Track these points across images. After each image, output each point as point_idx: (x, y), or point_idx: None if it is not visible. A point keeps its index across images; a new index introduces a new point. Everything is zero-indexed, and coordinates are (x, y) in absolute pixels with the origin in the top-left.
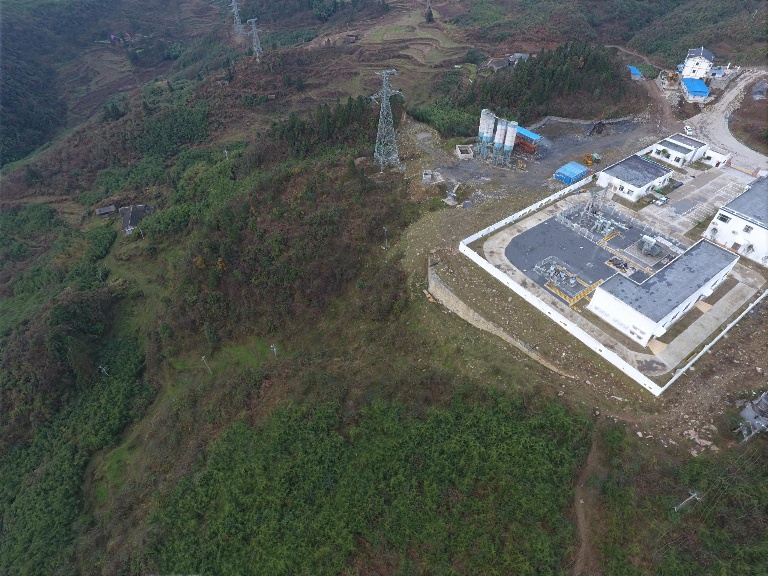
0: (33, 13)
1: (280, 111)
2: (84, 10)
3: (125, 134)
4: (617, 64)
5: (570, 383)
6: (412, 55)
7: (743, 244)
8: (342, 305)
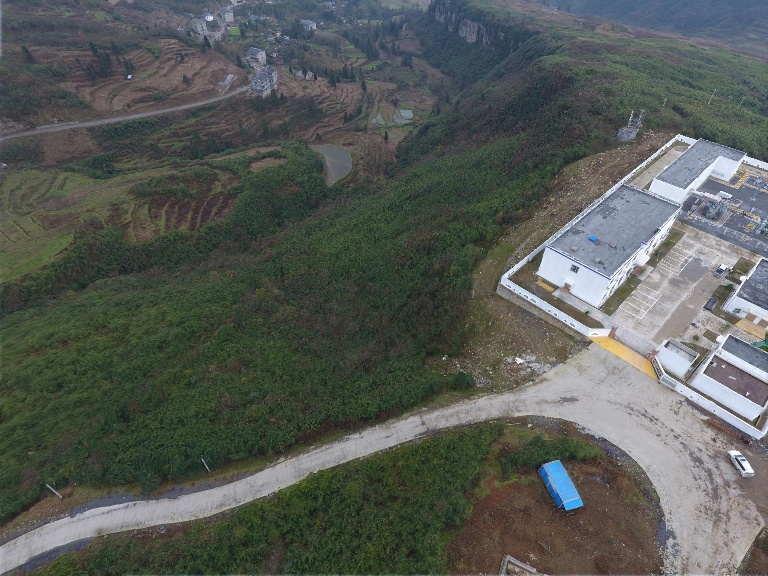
0: None
1: None
2: None
3: None
4: None
5: None
6: None
7: None
8: None
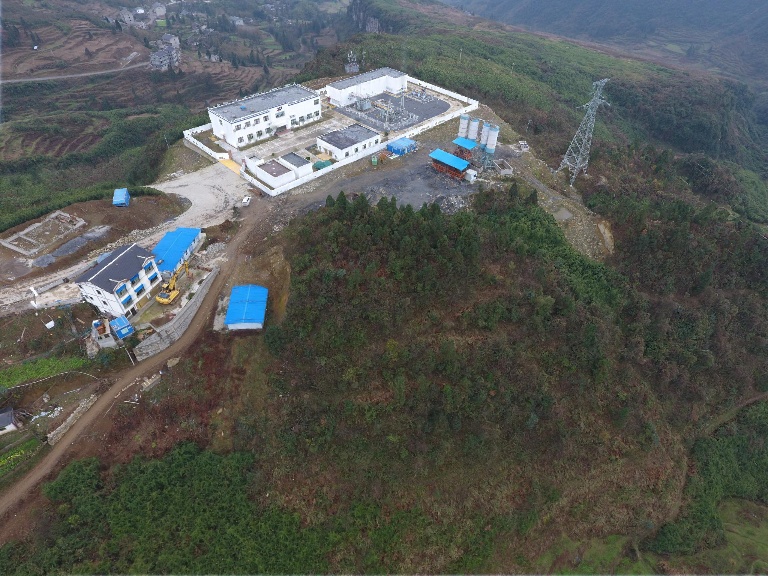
0: None
1: None
2: None
3: None
4: None
5: None
6: None
7: None
8: None
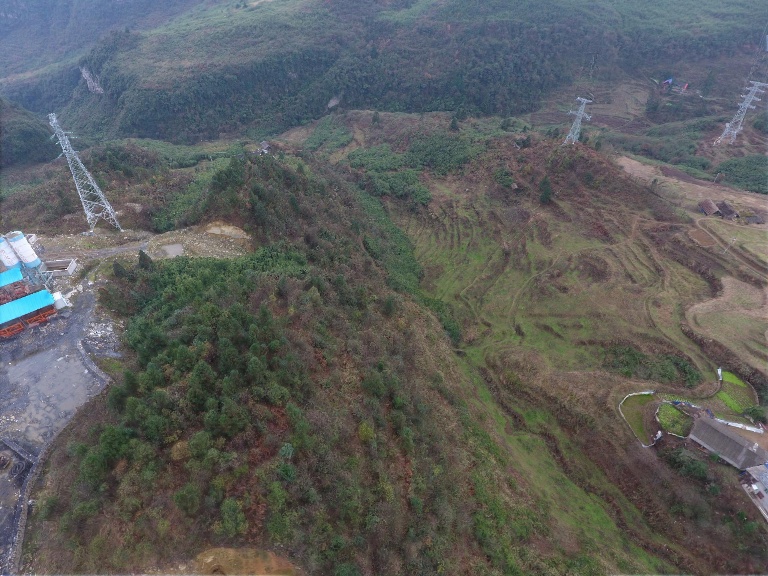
0: (633, 32)
1: (492, 202)
2: (678, 47)
3: (420, 131)
4: (122, 496)
5: None
6: (724, 295)
7: None
8: None
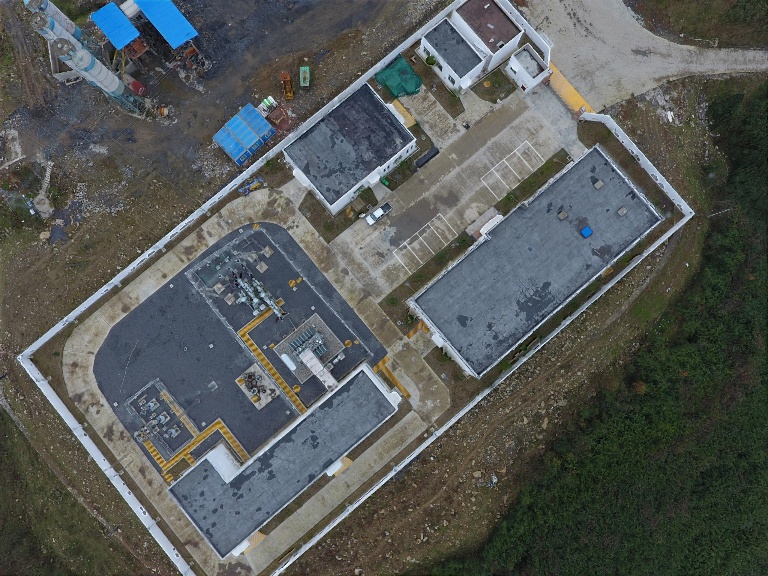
0: None
1: None
2: None
3: None
4: None
5: (152, 575)
6: None
7: (441, 346)
8: None
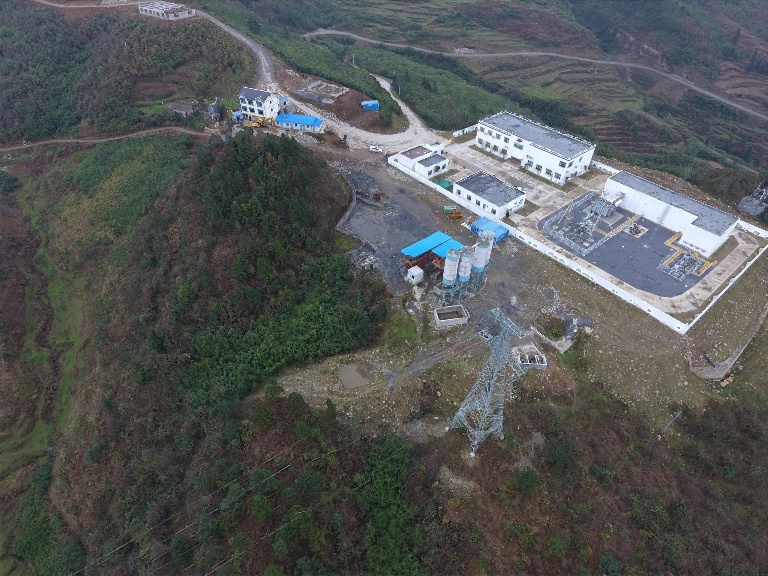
0: None
1: None
2: None
3: None
4: None
5: None
6: None
7: (581, 169)
8: (738, 509)
